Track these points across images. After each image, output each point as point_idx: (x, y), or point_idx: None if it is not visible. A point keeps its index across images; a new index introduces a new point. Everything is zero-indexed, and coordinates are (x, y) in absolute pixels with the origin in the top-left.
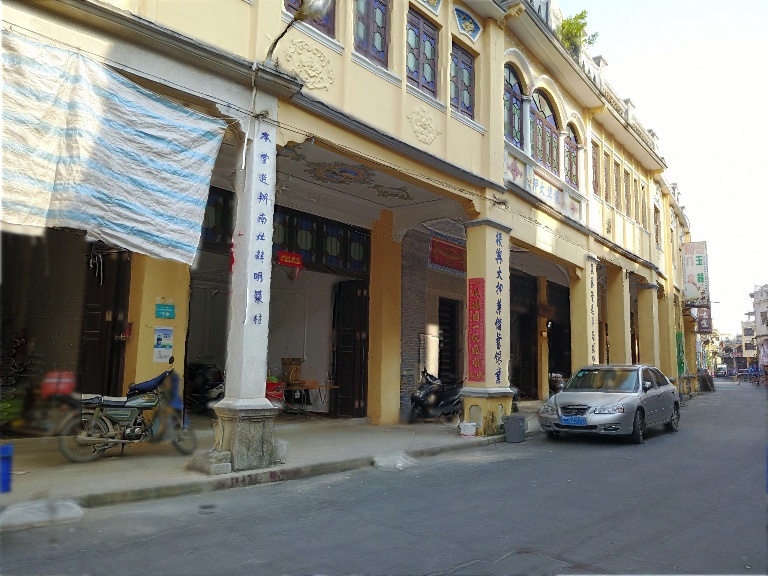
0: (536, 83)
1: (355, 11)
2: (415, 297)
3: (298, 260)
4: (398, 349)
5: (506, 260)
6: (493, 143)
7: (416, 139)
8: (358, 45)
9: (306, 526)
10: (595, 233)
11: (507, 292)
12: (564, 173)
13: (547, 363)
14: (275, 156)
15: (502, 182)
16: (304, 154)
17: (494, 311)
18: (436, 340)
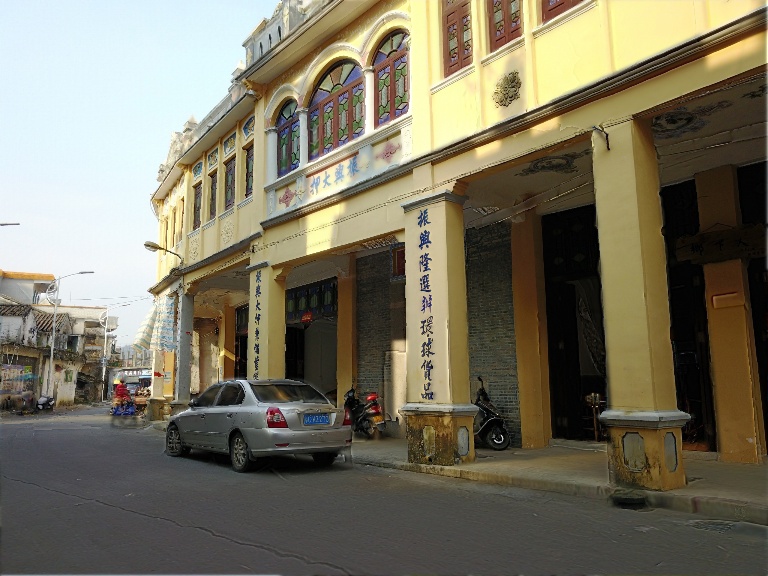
0: (310, 80)
1: (212, 198)
2: (378, 317)
3: (309, 316)
4: (349, 369)
5: (266, 291)
6: (255, 201)
7: (224, 244)
8: (213, 214)
9: (97, 433)
10: (419, 159)
11: (266, 318)
12: (370, 121)
13: (747, 366)
14: (182, 300)
15: (261, 227)
16: (245, 270)
17: (253, 339)
18: (405, 355)
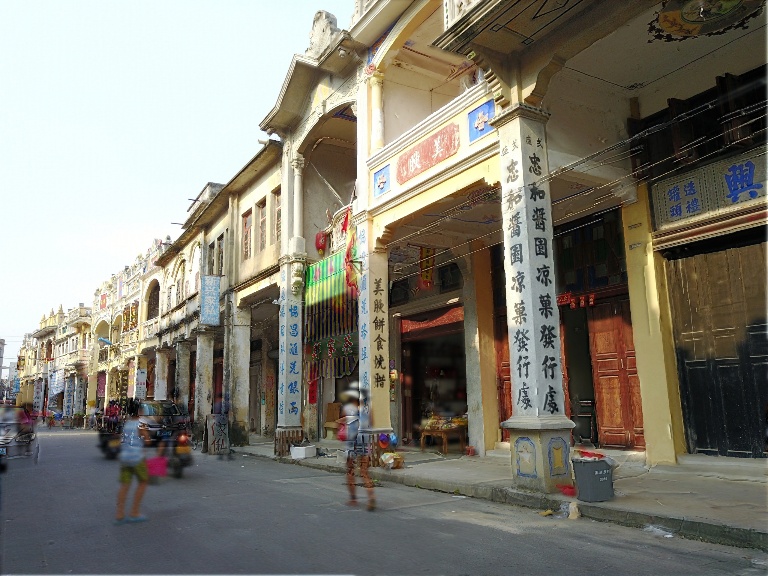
0: None
1: None
2: None
3: None
4: None
5: None
6: None
7: None
8: None
9: None
10: None
11: None
12: None
13: None
14: None
15: None
16: None
17: None
18: None
